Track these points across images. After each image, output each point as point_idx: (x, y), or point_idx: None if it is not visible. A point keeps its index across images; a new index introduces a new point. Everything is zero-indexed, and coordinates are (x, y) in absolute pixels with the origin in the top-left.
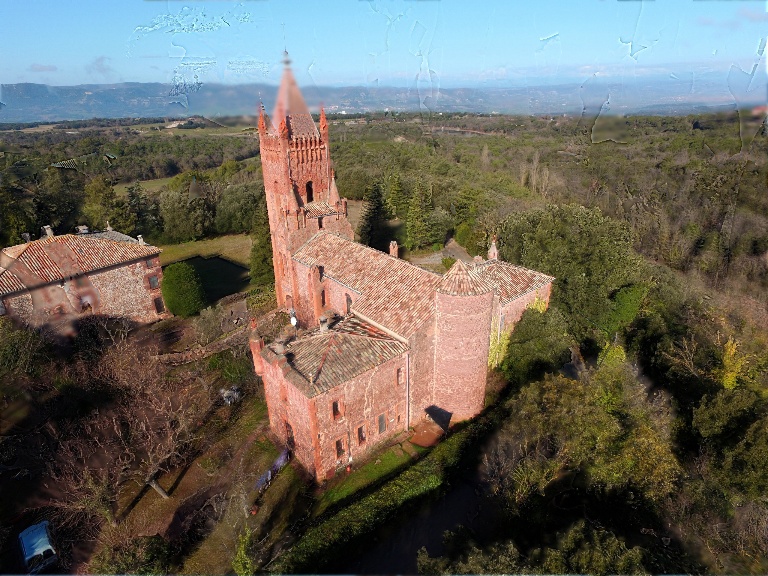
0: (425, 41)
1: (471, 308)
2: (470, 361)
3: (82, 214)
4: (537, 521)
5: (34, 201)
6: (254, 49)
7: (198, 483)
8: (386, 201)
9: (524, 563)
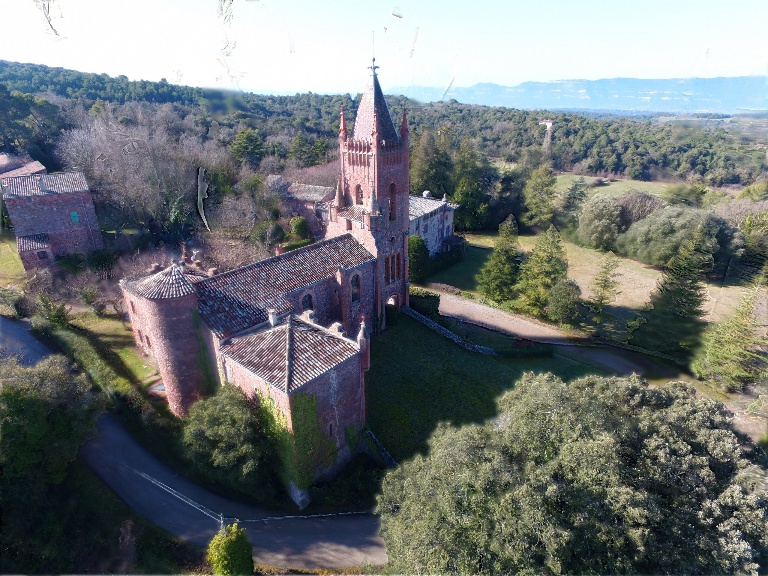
0: None
1: None
2: None
3: None
4: None
5: (505, 174)
6: None
7: None
8: (699, 283)
9: None
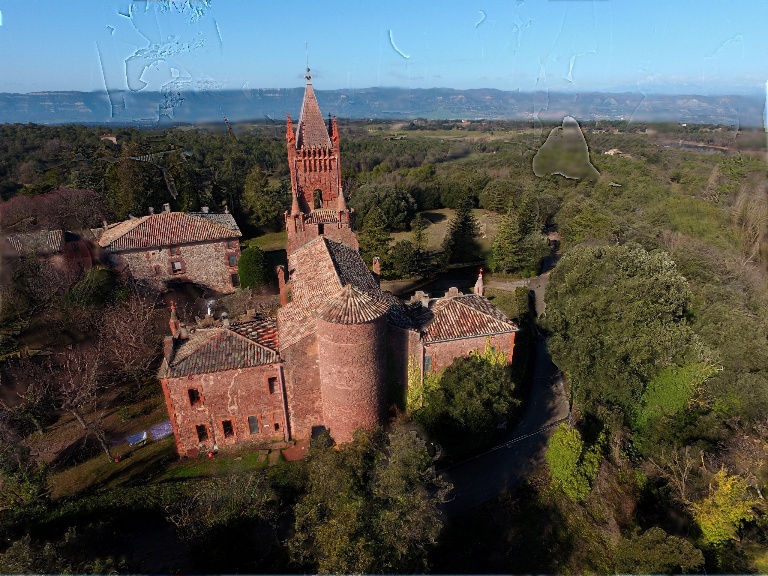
0: (546, 48)
1: (338, 336)
2: (344, 391)
3: (241, 198)
4: (212, 558)
5: (212, 184)
6: (209, 70)
7: (111, 424)
8: (475, 217)
9: (47, 567)
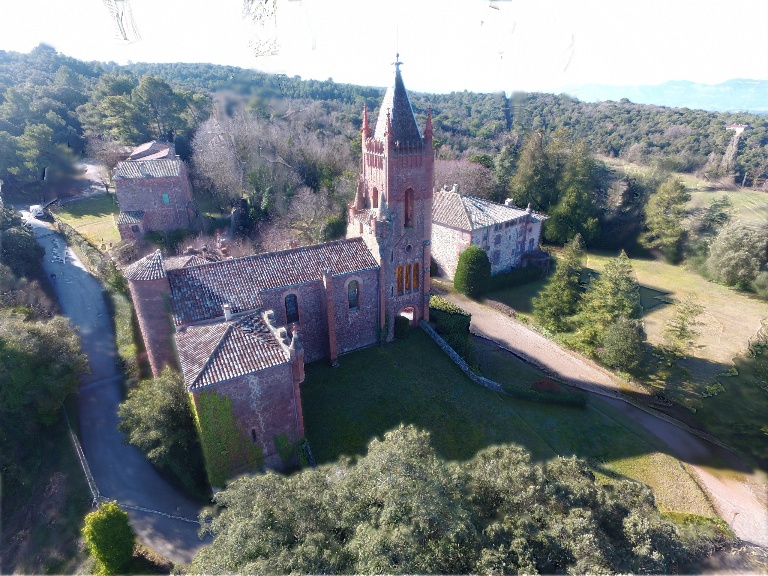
0: None
1: None
2: None
3: (643, 208)
4: None
5: (628, 185)
6: None
7: None
8: None
9: None
